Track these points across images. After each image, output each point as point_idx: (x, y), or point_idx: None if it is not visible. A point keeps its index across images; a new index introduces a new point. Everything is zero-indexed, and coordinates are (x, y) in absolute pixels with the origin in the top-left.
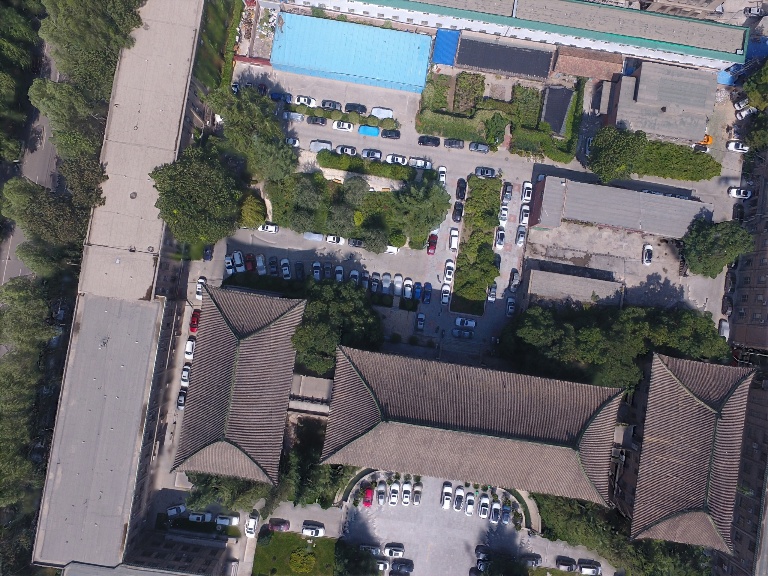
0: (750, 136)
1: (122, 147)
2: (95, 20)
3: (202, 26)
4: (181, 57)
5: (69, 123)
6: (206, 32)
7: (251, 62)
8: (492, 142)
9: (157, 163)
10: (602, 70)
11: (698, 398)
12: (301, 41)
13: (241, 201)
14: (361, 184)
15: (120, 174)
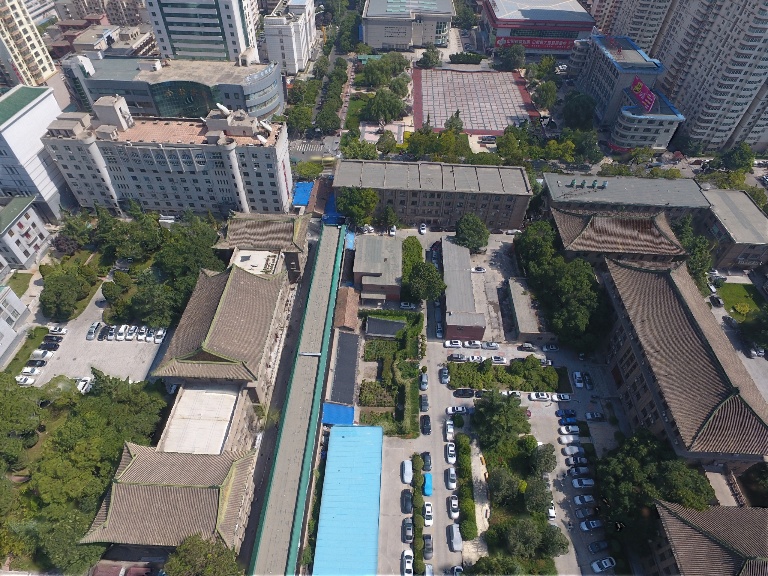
0: (390, 223)
1: None
2: None
3: None
4: None
5: None
6: None
7: None
8: (418, 372)
9: None
10: (353, 299)
11: (586, 226)
12: (345, 571)
13: None
14: None
15: None
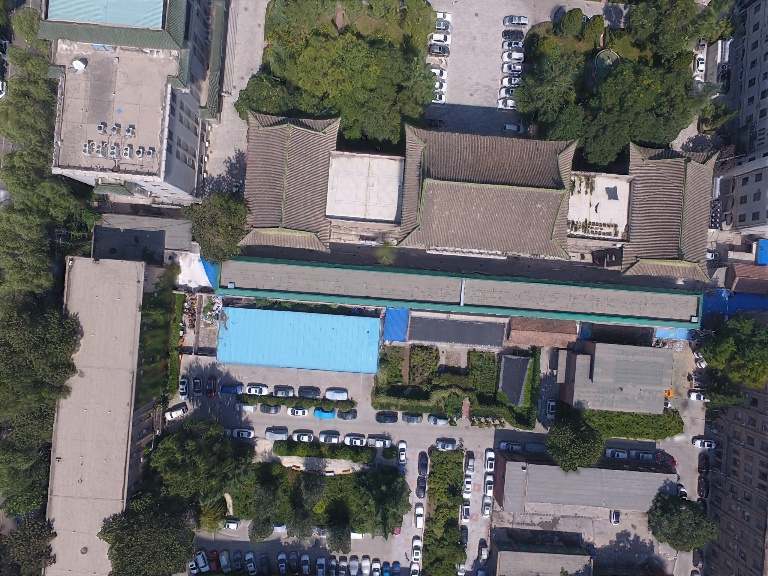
0: (710, 395)
1: (68, 501)
2: (25, 398)
3: (140, 358)
4: (120, 402)
5: (11, 479)
6: (145, 359)
7: (198, 353)
8: (451, 415)
9: (105, 515)
10: (557, 340)
11: None
12: (247, 336)
13: (199, 505)
14: (318, 494)
15: (68, 529)
